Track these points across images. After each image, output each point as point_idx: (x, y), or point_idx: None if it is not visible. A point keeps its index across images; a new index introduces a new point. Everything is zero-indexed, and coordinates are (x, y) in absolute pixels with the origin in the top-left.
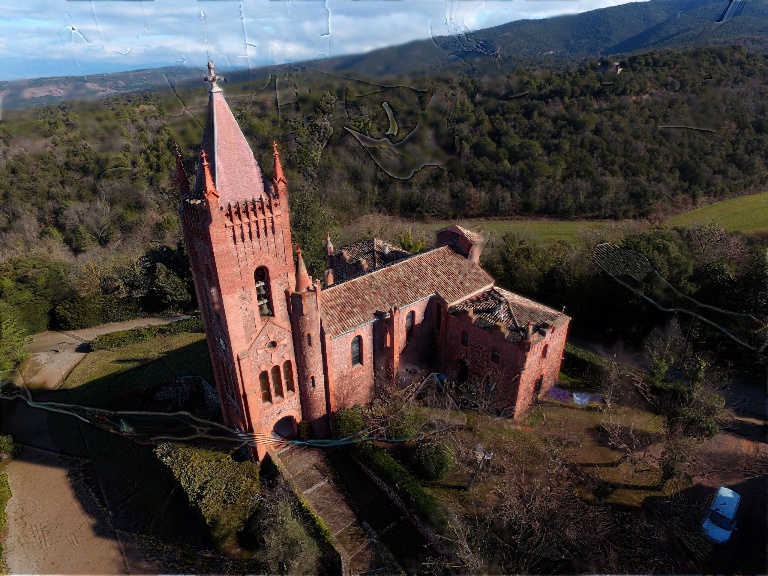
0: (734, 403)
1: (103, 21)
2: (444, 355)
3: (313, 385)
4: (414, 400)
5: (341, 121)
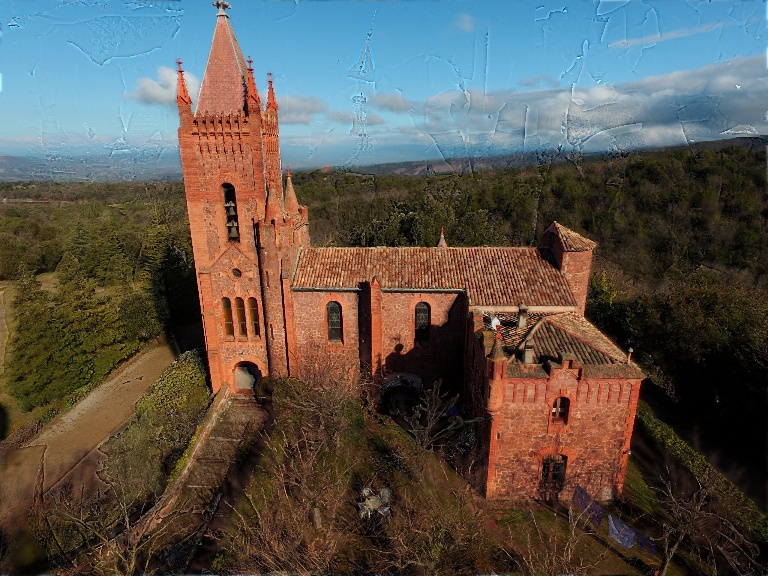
0: None
1: None
2: (465, 382)
3: (273, 336)
4: None
5: (598, 156)
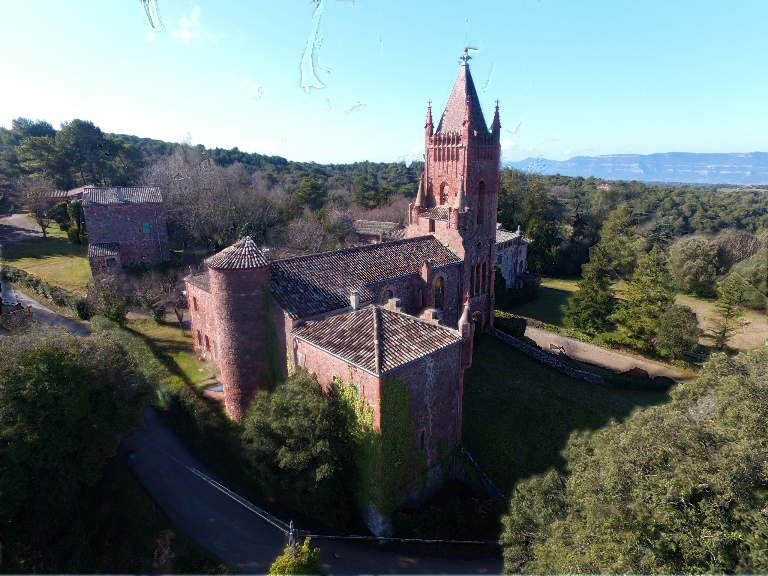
0: None
1: None
2: None
3: None
4: None
5: None
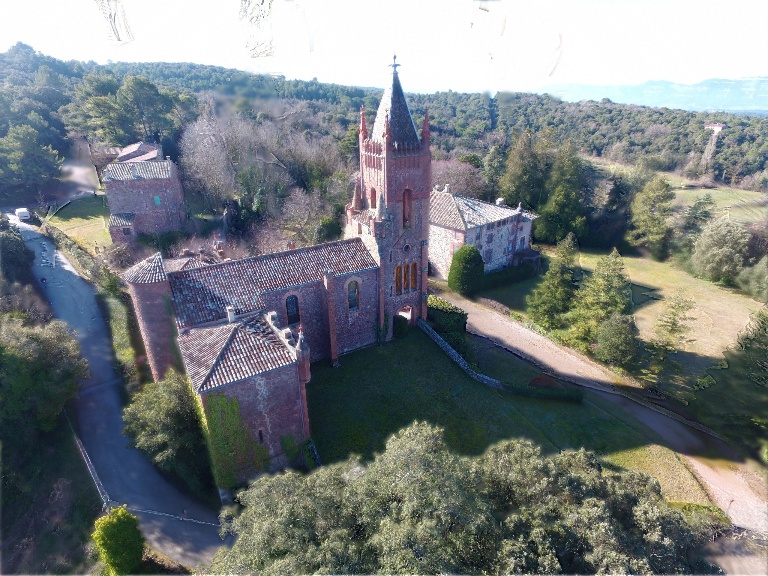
0: (86, 292)
1: None
2: None
3: None
4: None
5: None
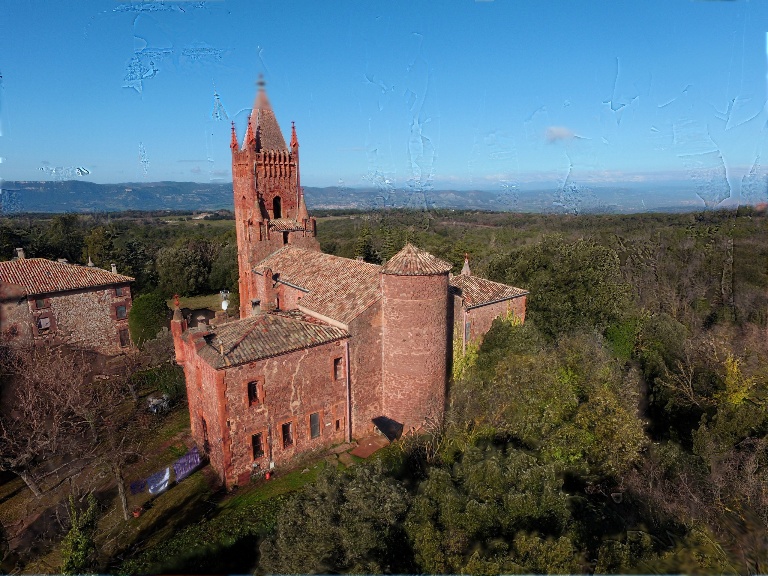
0: None
1: (623, 78)
2: None
3: None
4: (4, 162)
5: None
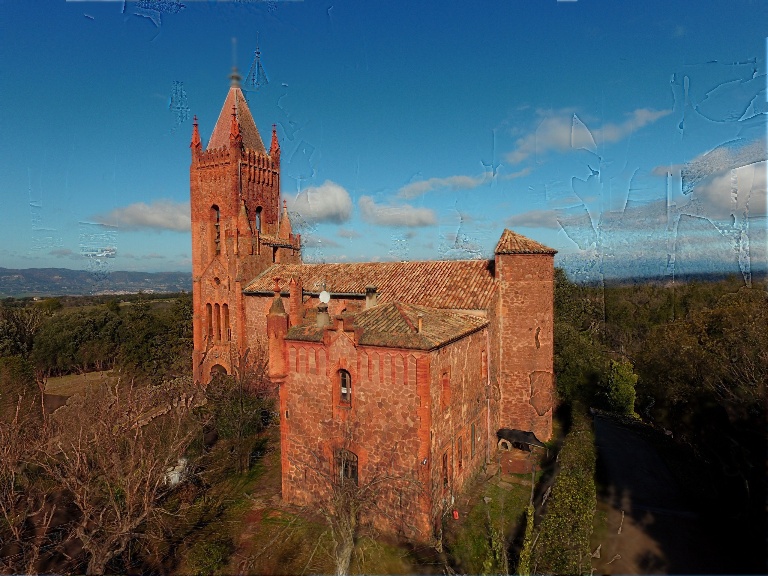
0: None
1: (499, 147)
2: None
3: None
4: None
5: None
